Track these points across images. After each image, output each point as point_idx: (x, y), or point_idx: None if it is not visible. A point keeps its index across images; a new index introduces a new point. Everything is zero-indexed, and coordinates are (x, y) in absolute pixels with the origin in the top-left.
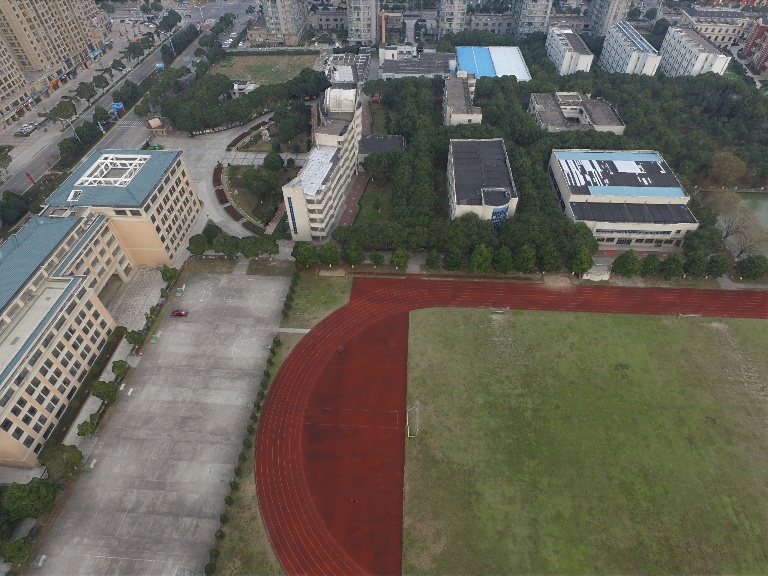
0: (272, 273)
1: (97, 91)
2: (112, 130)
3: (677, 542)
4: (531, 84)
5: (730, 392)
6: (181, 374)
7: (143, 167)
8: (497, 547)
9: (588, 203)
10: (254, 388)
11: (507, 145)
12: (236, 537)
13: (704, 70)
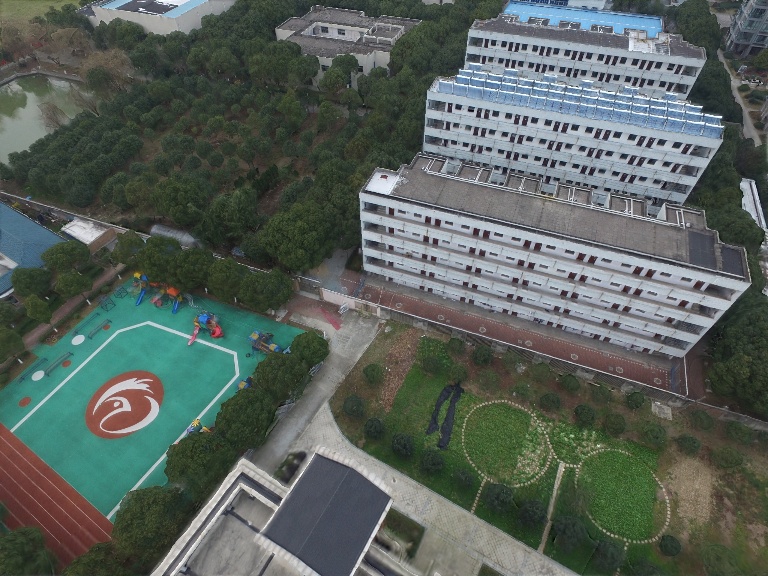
0: None
1: None
2: None
3: None
4: None
5: None
6: None
7: None
8: None
9: None
10: None
11: None
12: None
13: None
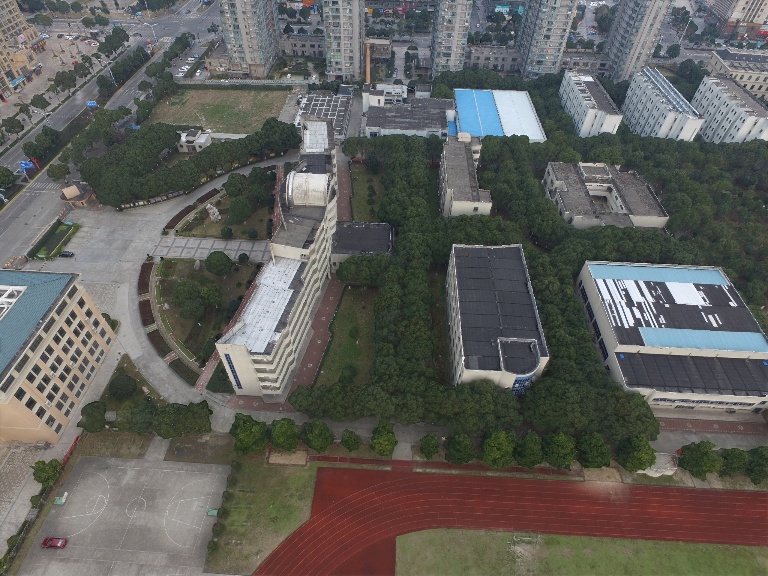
0: (202, 458)
1: (10, 135)
2: (18, 197)
3: None
4: (547, 149)
5: None
6: None
7: (10, 311)
8: None
9: (640, 354)
10: None
11: (525, 251)
12: None
13: (751, 135)
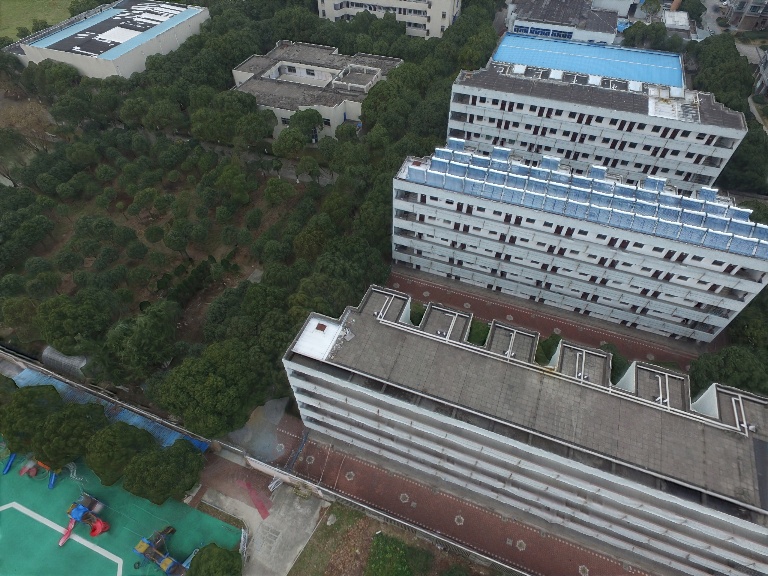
0: None
1: None
2: None
3: None
4: None
5: None
6: None
7: None
8: None
9: None
10: None
11: None
12: None
13: None
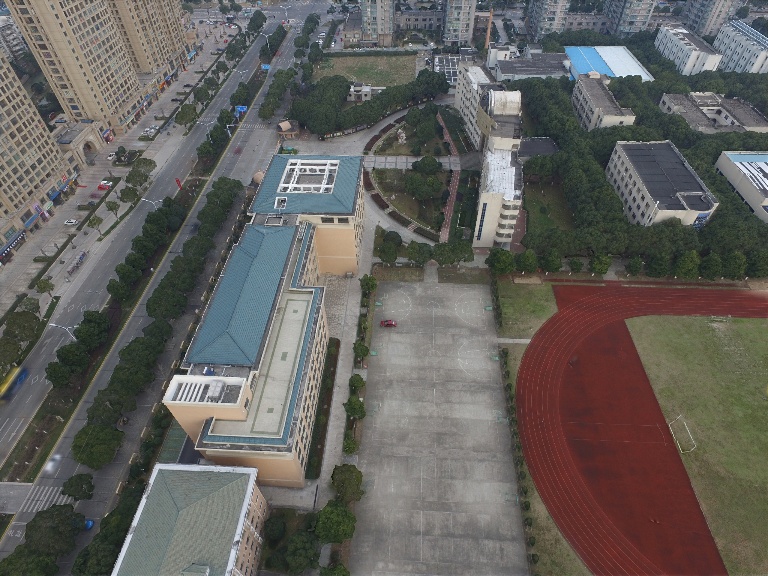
0: (465, 281)
1: None
2: (237, 133)
3: None
4: (659, 84)
5: None
6: (416, 387)
7: (338, 173)
8: None
9: None
10: (498, 402)
11: None
12: (548, 561)
13: None
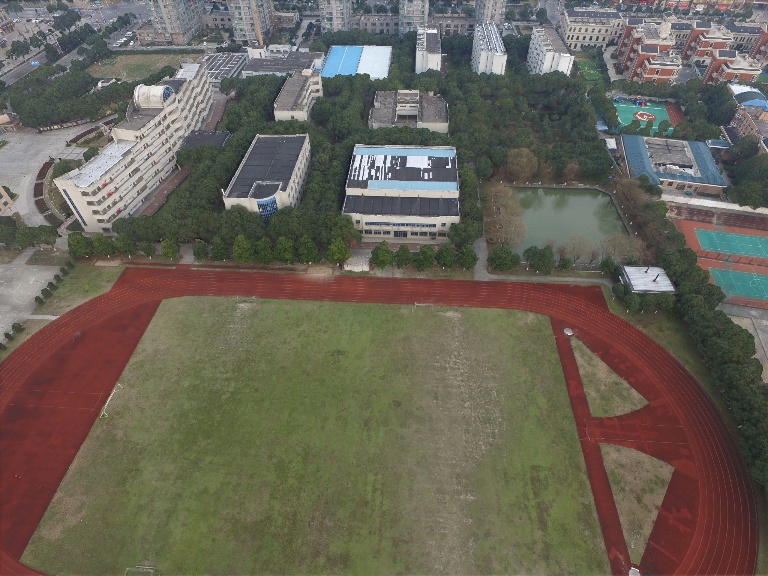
0: (50, 263)
1: None
2: None
3: (303, 516)
4: (380, 82)
5: (429, 377)
6: None
7: None
8: (130, 520)
9: (364, 197)
10: None
11: (316, 141)
12: None
13: (553, 69)
